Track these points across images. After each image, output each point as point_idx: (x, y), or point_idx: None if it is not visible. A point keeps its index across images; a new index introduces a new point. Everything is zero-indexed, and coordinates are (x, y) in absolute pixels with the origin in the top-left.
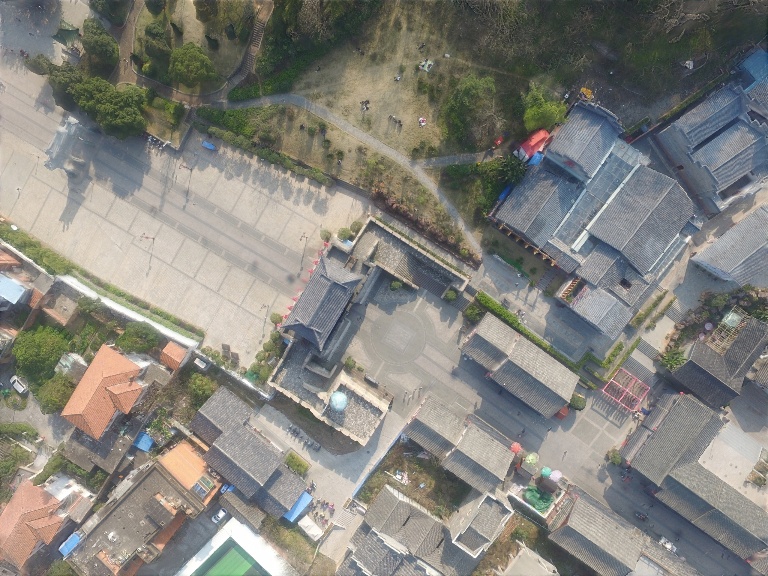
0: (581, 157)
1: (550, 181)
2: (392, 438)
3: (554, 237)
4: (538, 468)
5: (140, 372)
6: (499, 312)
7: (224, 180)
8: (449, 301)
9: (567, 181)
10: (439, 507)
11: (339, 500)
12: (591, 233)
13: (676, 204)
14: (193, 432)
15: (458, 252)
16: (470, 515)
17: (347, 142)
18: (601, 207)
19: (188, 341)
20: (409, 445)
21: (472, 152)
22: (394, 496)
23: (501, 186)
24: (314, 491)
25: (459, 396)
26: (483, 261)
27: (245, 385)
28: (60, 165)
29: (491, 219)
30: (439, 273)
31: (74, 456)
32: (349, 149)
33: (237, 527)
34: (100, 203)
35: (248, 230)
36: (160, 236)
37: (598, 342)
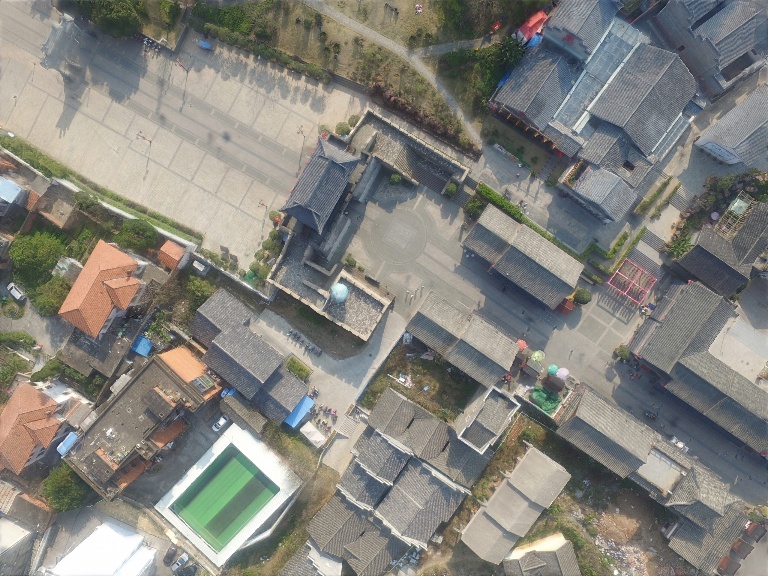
0: (580, 32)
1: (549, 60)
2: (394, 340)
3: (555, 120)
4: (544, 368)
5: (138, 270)
6: (501, 203)
7: (220, 81)
8: (450, 197)
9: (566, 63)
10: (444, 410)
11: (342, 407)
12: (592, 113)
13: (678, 80)
14: (192, 337)
15: (458, 144)
16: (475, 409)
17: (343, 34)
18: (602, 88)
19: (186, 242)
20: (412, 346)
21: (470, 39)
22: (397, 396)
23: (500, 72)
24: (316, 398)
25: (462, 295)
26: (483, 152)
27: (244, 289)
28: (56, 66)
29: (490, 107)
30: (439, 167)
31: (72, 360)
32: (345, 41)
33: (238, 433)
34: (96, 108)
35: (245, 131)
36: (157, 139)
37: (602, 233)
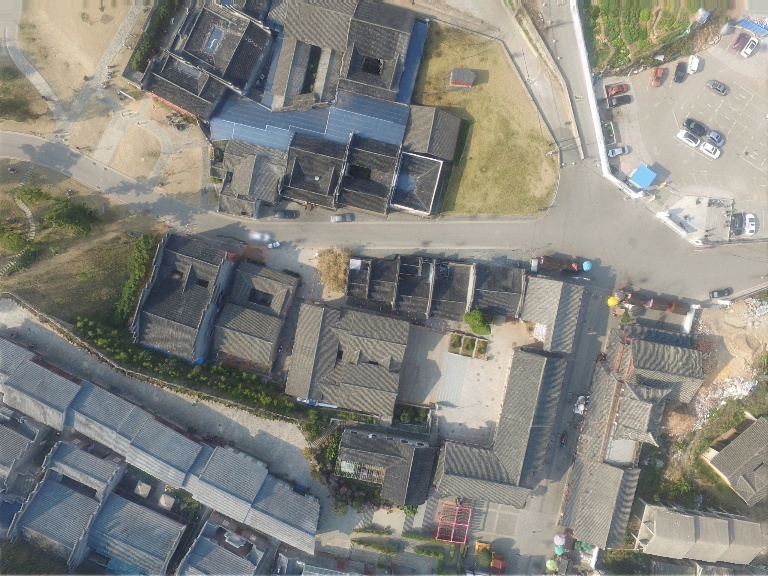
0: None
1: None
2: None
3: None
4: None
5: None
6: None
7: None
8: None
9: None
10: None
11: None
12: None
13: None
14: None
15: None
16: None
17: None
18: None
19: None
20: None
21: None
22: None
23: None
24: None
25: None
26: None
27: None
28: None
29: None
30: None
31: None
32: None
33: None
34: None
35: None
36: None
37: (423, 568)
